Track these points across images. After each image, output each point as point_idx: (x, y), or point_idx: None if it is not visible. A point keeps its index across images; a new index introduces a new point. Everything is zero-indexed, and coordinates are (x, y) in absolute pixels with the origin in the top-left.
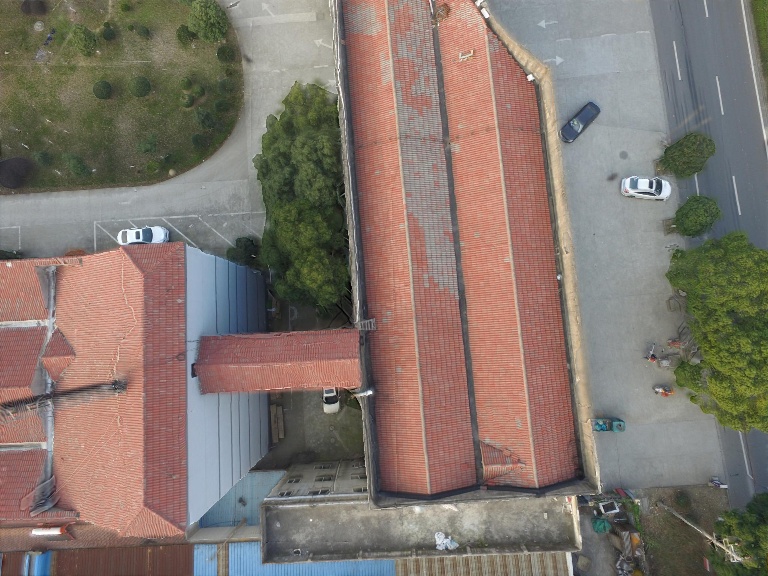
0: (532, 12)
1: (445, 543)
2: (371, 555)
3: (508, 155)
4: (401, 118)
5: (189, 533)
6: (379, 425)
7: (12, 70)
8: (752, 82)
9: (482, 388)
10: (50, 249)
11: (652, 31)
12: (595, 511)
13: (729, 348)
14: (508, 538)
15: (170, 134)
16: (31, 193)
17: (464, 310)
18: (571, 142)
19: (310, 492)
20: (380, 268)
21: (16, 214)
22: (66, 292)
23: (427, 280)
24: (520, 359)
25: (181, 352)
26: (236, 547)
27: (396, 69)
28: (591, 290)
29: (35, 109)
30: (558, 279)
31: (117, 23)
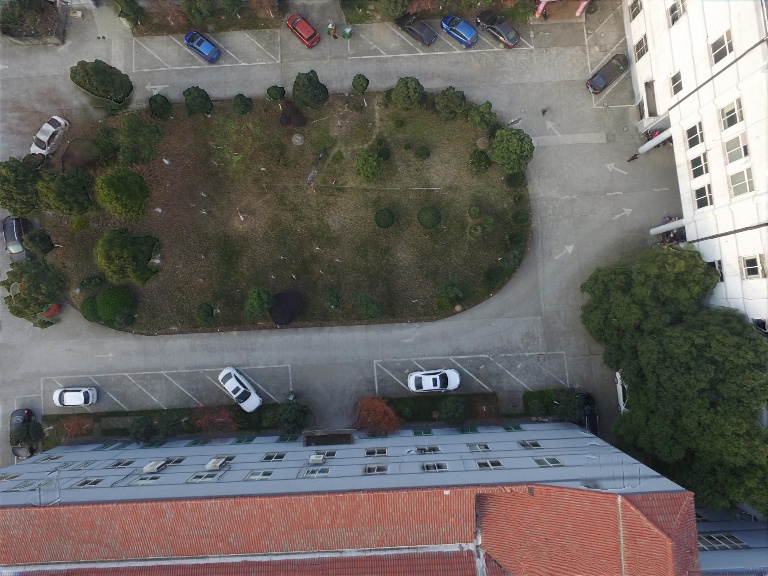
0: None
1: None
2: None
3: None
4: None
5: None
6: None
7: (271, 189)
8: None
9: None
10: (326, 391)
11: None
12: None
13: None
14: None
15: (455, 266)
16: (300, 328)
17: None
18: None
19: None
20: None
21: (284, 351)
22: (494, 513)
23: None
24: None
25: None
26: None
27: None
28: None
29: (301, 234)
30: None
31: (387, 139)
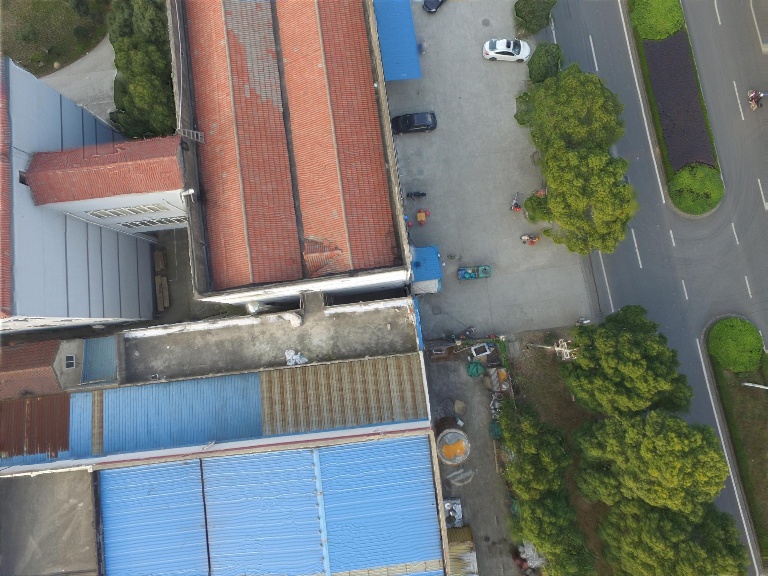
0: None
1: (294, 359)
2: None
3: None
4: None
5: (66, 385)
6: (210, 230)
7: None
8: None
9: (304, 188)
10: None
11: None
12: (469, 357)
13: (560, 163)
14: (354, 350)
15: (54, 29)
16: None
17: (289, 121)
18: (434, 12)
19: None
20: (207, 85)
21: None
22: None
23: (248, 91)
24: (334, 154)
25: (3, 153)
26: (110, 393)
27: None
28: (458, 150)
29: None
30: (375, 86)
31: None
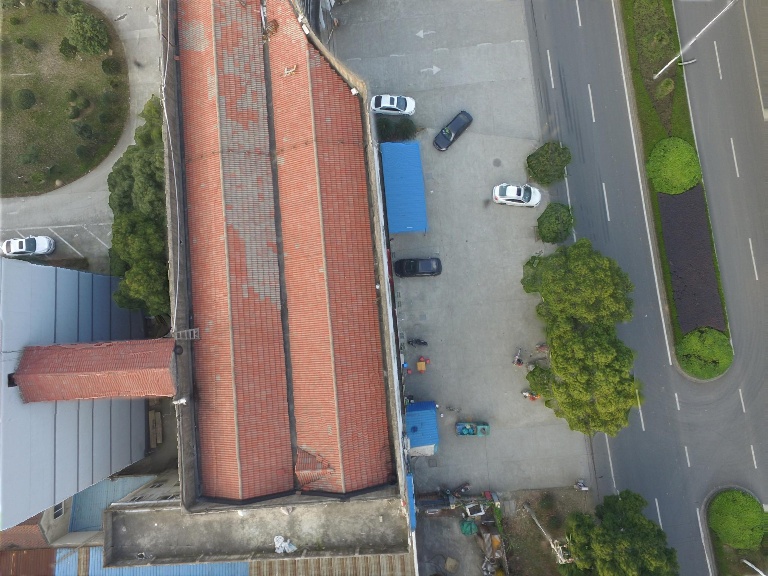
0: (411, 22)
1: (283, 546)
2: (210, 558)
3: (326, 168)
4: (224, 132)
5: (54, 537)
6: (201, 432)
7: None
8: (623, 90)
9: (299, 395)
10: None
11: (527, 40)
12: (463, 513)
13: (564, 354)
14: (344, 541)
15: (57, 145)
16: None
17: (287, 319)
18: (445, 150)
19: (159, 497)
20: (204, 279)
21: None
22: None
23: (246, 290)
24: (331, 367)
25: None
26: (97, 551)
27: (221, 84)
28: (463, 296)
29: None
30: (377, 288)
31: (8, 36)
